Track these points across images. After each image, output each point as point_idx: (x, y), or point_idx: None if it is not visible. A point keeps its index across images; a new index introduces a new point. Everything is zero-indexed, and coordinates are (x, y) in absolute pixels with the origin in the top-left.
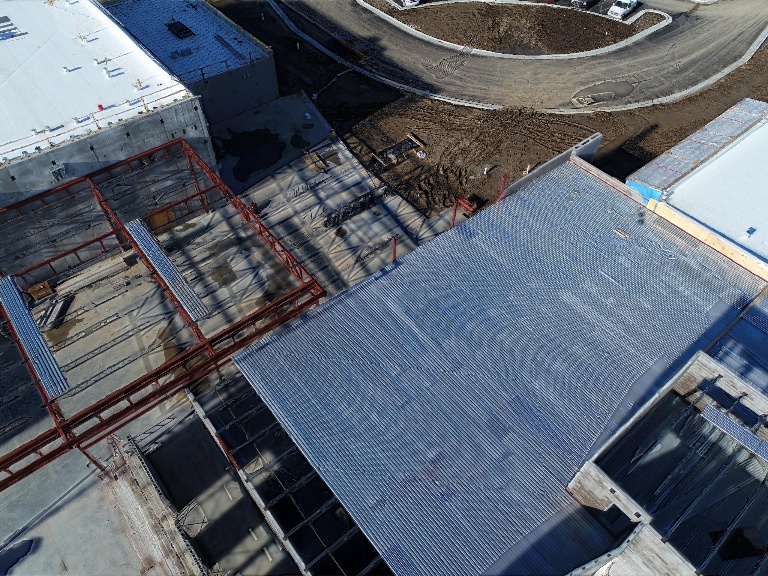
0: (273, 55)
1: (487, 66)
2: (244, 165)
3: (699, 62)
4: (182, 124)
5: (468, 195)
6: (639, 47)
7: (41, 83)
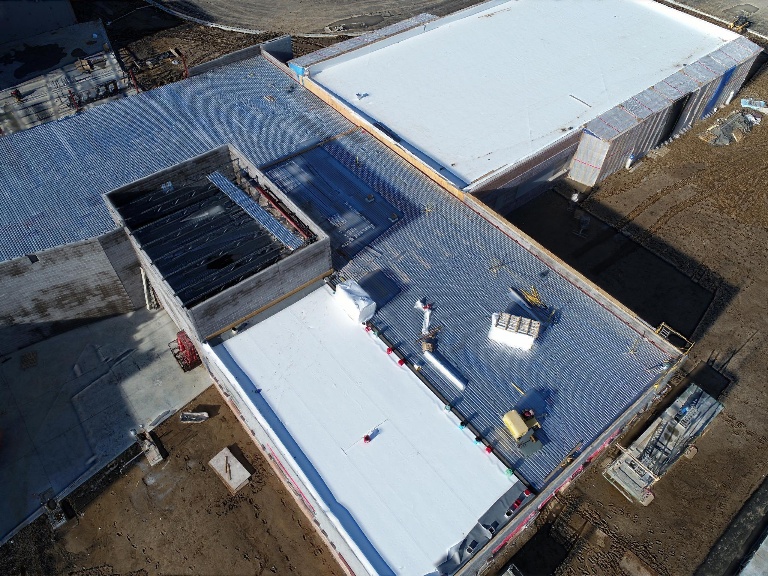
0: None
1: (269, 4)
2: (26, 68)
3: (451, 2)
4: None
5: None
6: None
7: None
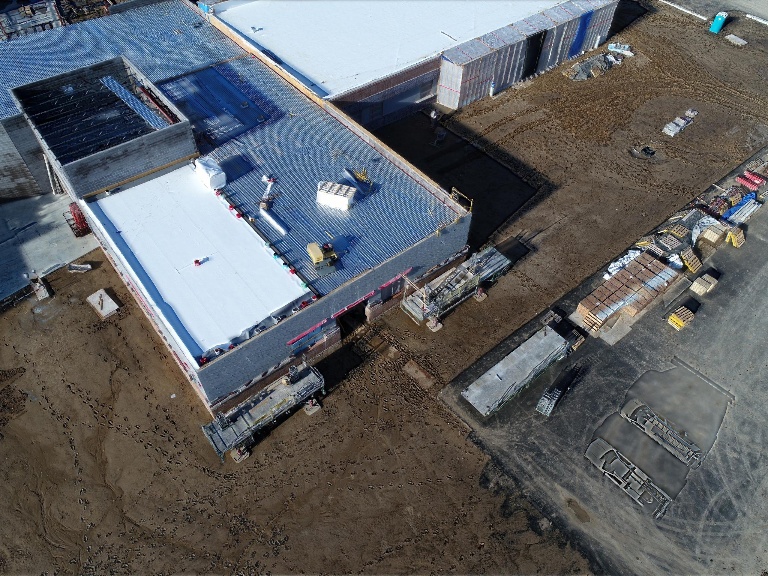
0: None
1: None
2: None
3: None
4: None
5: None
6: None
7: None
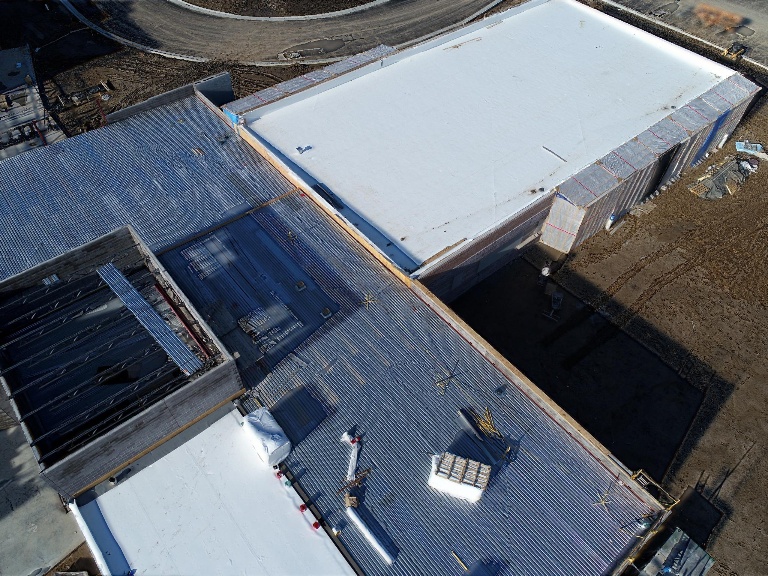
0: None
1: (219, 26)
2: None
3: (420, 24)
4: None
5: None
6: (373, 11)
7: None
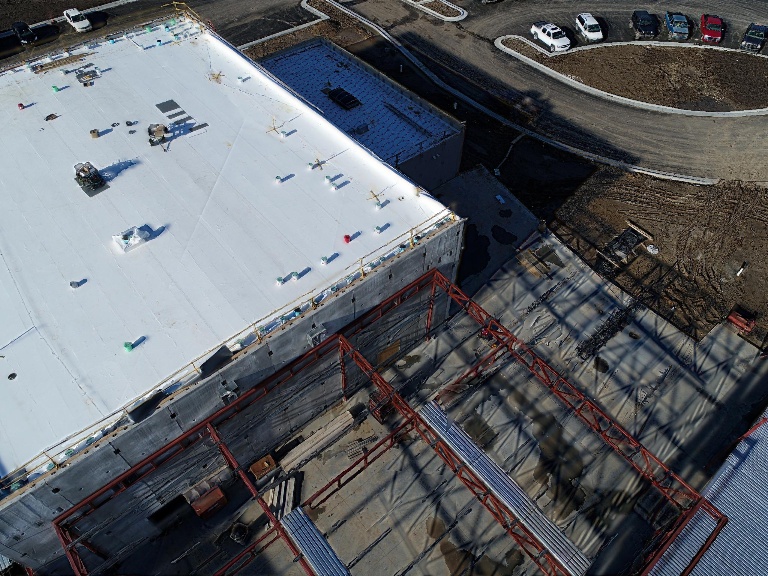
0: (464, 130)
1: (676, 127)
2: None
3: None
4: (440, 252)
5: (731, 306)
6: None
7: (254, 200)
